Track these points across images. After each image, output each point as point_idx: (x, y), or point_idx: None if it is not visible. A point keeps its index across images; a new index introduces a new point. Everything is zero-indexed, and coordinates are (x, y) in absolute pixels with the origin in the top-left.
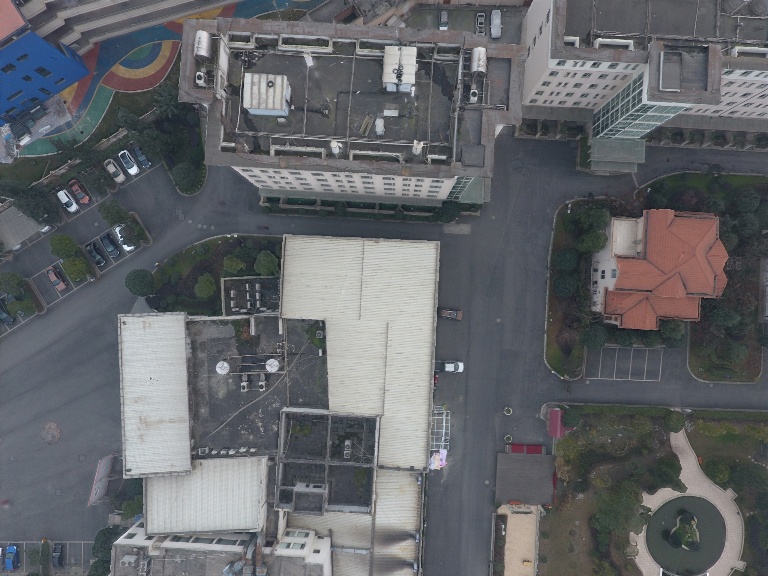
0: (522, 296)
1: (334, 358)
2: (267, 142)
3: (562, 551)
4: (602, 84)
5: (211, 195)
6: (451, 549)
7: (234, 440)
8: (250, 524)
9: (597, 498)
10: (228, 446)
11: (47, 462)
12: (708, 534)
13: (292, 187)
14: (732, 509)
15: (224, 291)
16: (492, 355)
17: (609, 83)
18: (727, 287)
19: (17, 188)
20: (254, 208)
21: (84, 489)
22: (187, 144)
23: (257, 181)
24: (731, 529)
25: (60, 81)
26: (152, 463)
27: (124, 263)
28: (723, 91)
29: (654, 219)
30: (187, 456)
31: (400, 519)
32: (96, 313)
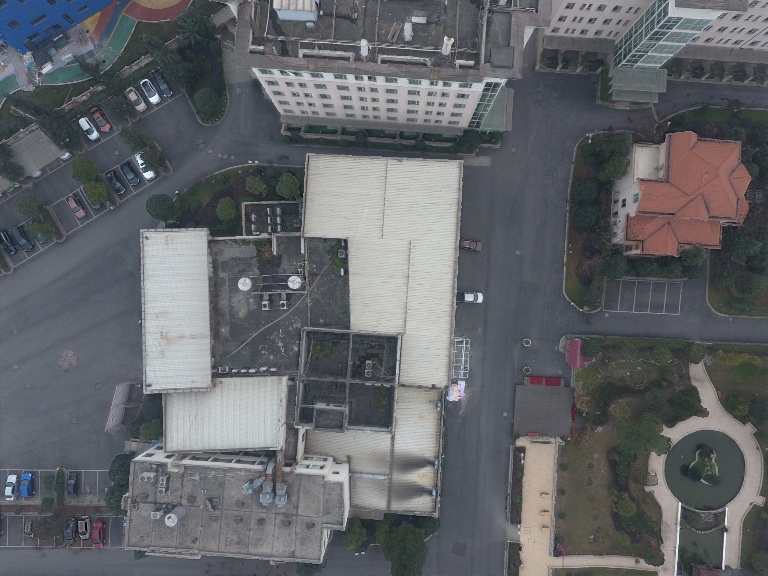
0: (542, 228)
1: (356, 276)
2: (295, 47)
3: (580, 484)
4: (626, 5)
5: (232, 125)
6: (468, 481)
7: (254, 360)
8: (270, 443)
9: (617, 425)
10: (248, 366)
11: (63, 390)
12: (727, 469)
13: (314, 112)
14: (751, 443)
15: (245, 216)
16: (511, 287)
17: (633, 4)
18: (747, 220)
19: (40, 108)
20: (275, 138)
21: (100, 417)
22: (209, 74)
23: (280, 103)
24: (750, 464)
25: (83, 9)
26: (172, 379)
27: (144, 192)
28: (747, 14)
29: (677, 142)
30: (208, 372)
31: (419, 445)
32: (115, 241)
